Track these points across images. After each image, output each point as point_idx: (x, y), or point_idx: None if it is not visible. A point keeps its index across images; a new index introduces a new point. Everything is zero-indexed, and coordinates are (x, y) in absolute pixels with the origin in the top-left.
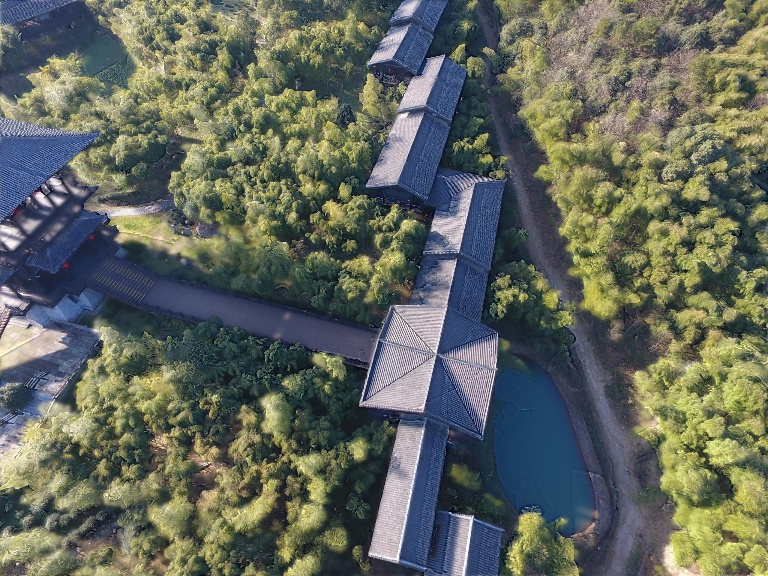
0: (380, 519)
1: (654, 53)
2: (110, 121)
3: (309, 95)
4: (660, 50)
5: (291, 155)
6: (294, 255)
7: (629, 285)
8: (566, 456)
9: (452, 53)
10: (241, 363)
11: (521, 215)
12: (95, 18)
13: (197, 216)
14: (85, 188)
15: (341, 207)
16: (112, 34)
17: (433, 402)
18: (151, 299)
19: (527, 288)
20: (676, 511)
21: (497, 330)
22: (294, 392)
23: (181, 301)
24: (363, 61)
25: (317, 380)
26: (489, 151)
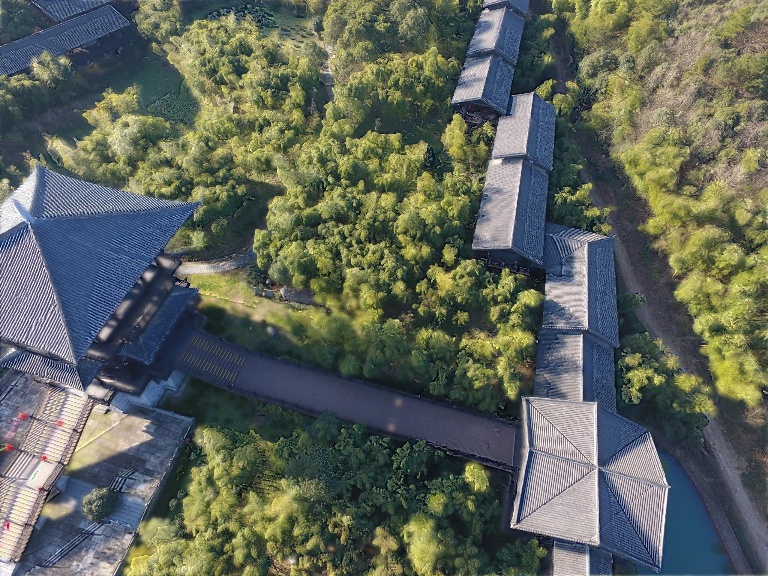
0: None
1: (760, 94)
2: (182, 169)
3: (394, 138)
4: (767, 91)
5: (389, 213)
6: (402, 330)
7: (766, 362)
8: (712, 561)
9: (536, 88)
10: (370, 474)
11: (621, 270)
12: (144, 43)
13: (284, 279)
14: (175, 259)
15: (449, 273)
16: (162, 60)
17: (605, 530)
18: (243, 380)
19: (658, 367)
20: None
21: (621, 411)
22: (433, 509)
23: (277, 382)
24: (442, 97)
25: (459, 495)
26: (591, 202)
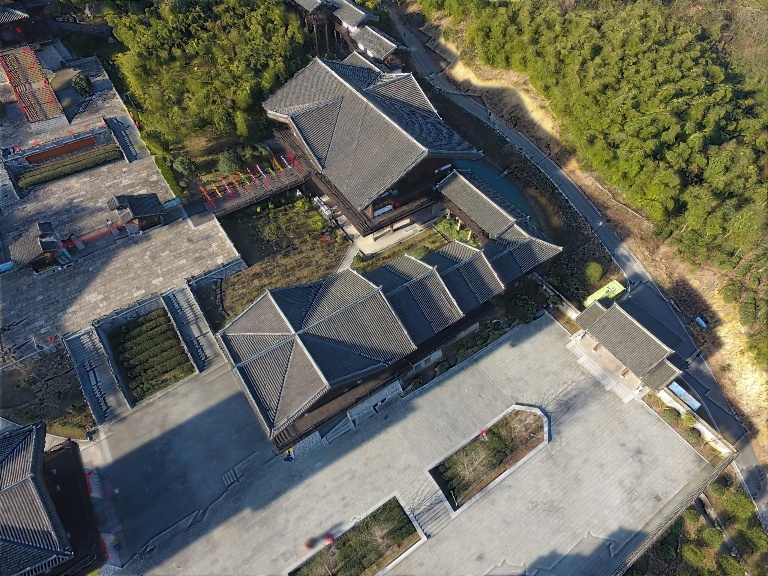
0: (304, 5)
1: None
2: None
3: None
4: None
5: None
6: None
7: None
8: None
9: None
10: None
11: None
12: None
13: None
14: None
15: None
16: None
17: None
18: None
19: None
20: (402, 2)
21: None
22: None
23: None
24: None
25: None
26: None
